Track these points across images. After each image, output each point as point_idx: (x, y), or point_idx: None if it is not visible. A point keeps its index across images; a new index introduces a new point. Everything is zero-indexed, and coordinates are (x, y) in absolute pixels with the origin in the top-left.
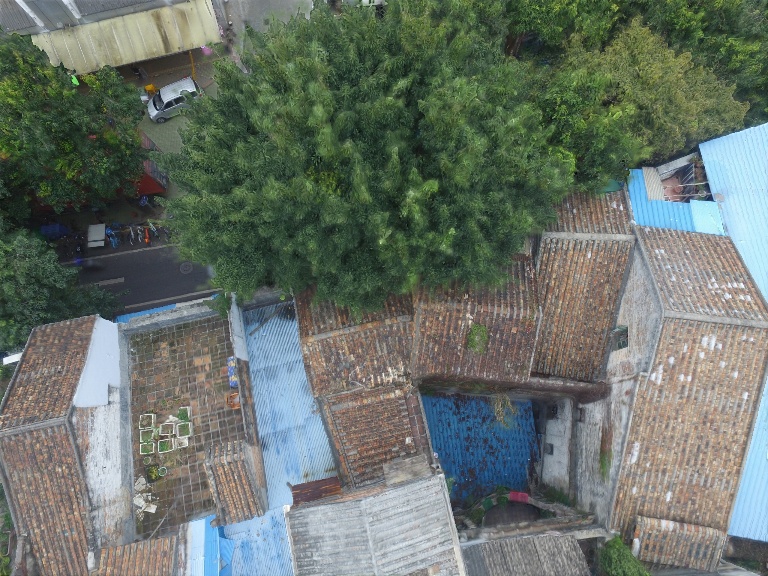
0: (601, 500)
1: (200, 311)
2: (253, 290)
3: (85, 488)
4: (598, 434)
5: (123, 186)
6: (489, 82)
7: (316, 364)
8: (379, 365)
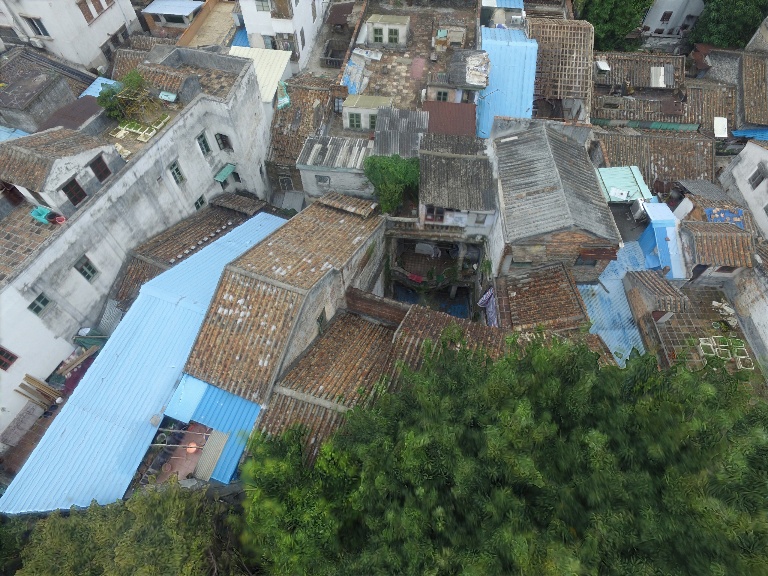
0: None
1: None
2: None
3: None
4: None
5: None
6: (408, 570)
7: None
8: None
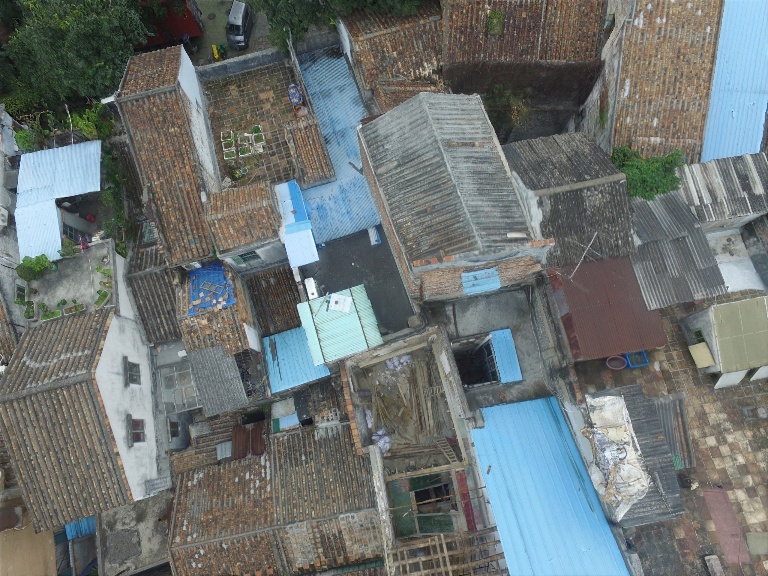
0: (603, 143)
1: (262, 53)
2: (306, 26)
3: (194, 144)
4: (597, 105)
5: (173, 4)
6: None
7: (366, 61)
8: (417, 61)
